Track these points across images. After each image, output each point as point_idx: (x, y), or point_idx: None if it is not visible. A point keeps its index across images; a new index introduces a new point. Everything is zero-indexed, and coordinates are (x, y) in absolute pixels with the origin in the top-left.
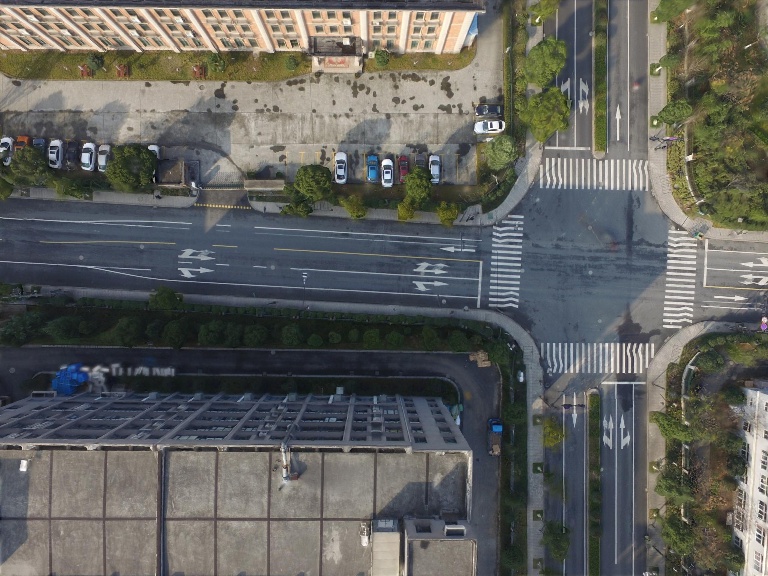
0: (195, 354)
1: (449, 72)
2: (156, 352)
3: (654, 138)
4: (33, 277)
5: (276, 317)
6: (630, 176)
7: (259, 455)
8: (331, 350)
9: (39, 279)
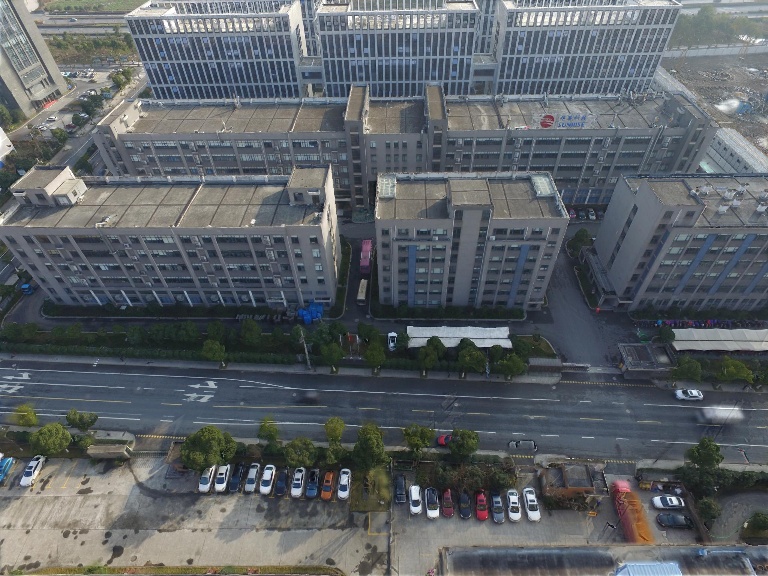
0: None
1: None
2: None
3: None
4: (336, 381)
5: None
6: None
7: None
8: (120, 333)
9: (332, 380)
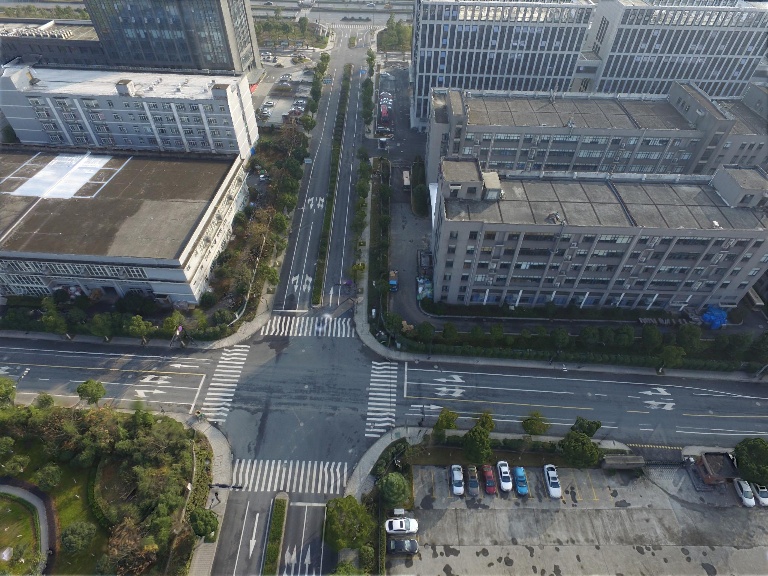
0: None
1: None
2: None
3: (238, 487)
4: None
5: None
6: (253, 474)
7: None
8: None
9: None
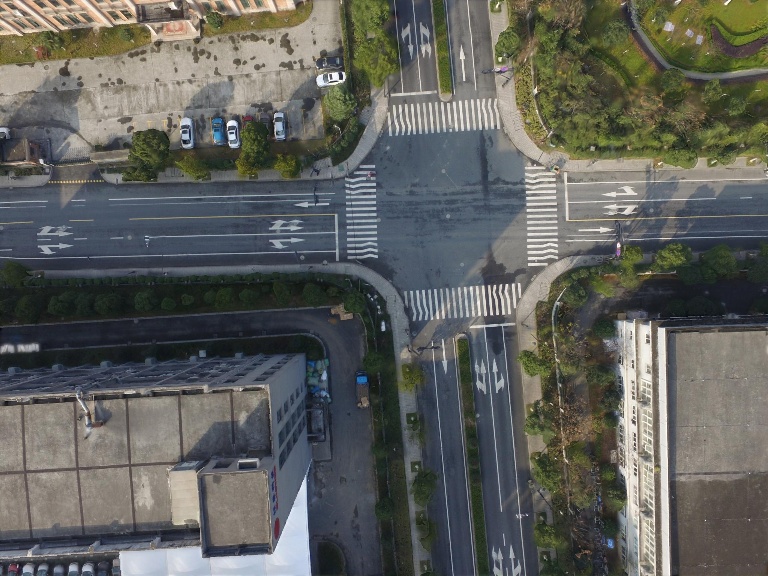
0: (60, 329)
1: (287, 29)
2: (22, 330)
3: (486, 71)
4: None
5: (134, 285)
6: (480, 116)
7: (64, 405)
8: (193, 315)
9: None
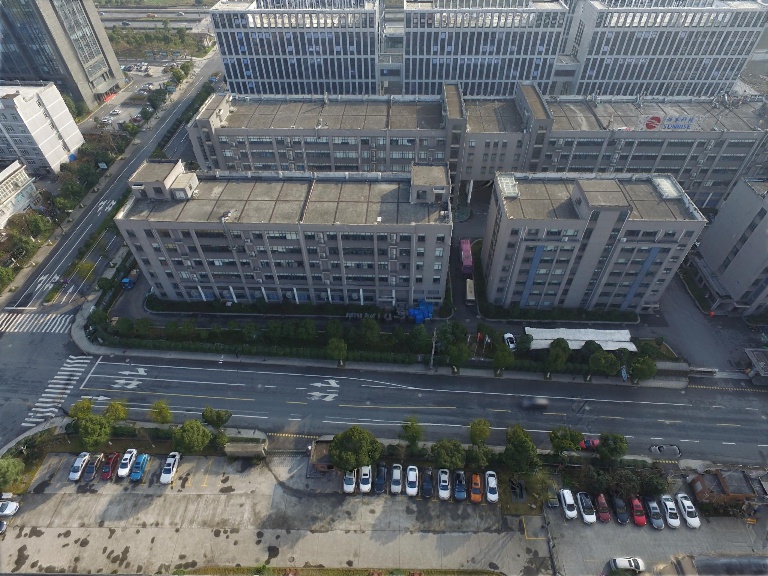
0: None
1: None
2: None
3: None
4: (459, 381)
5: None
6: None
7: None
8: None
9: (455, 380)
